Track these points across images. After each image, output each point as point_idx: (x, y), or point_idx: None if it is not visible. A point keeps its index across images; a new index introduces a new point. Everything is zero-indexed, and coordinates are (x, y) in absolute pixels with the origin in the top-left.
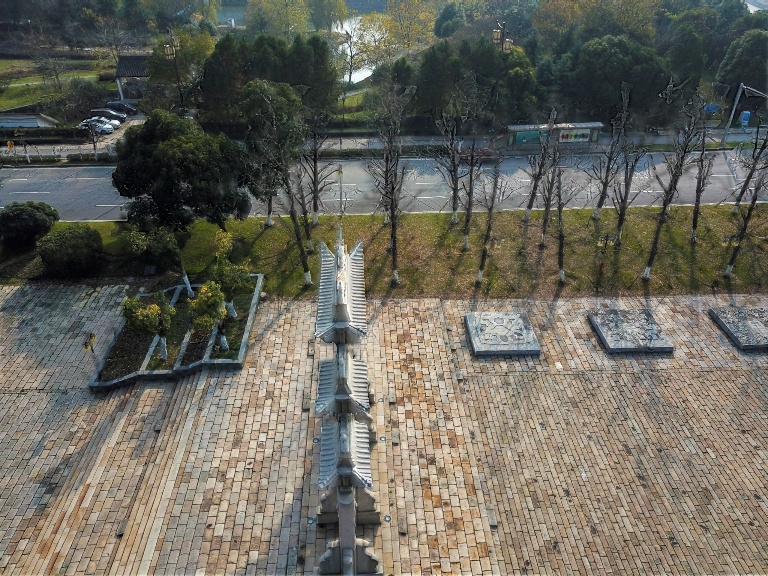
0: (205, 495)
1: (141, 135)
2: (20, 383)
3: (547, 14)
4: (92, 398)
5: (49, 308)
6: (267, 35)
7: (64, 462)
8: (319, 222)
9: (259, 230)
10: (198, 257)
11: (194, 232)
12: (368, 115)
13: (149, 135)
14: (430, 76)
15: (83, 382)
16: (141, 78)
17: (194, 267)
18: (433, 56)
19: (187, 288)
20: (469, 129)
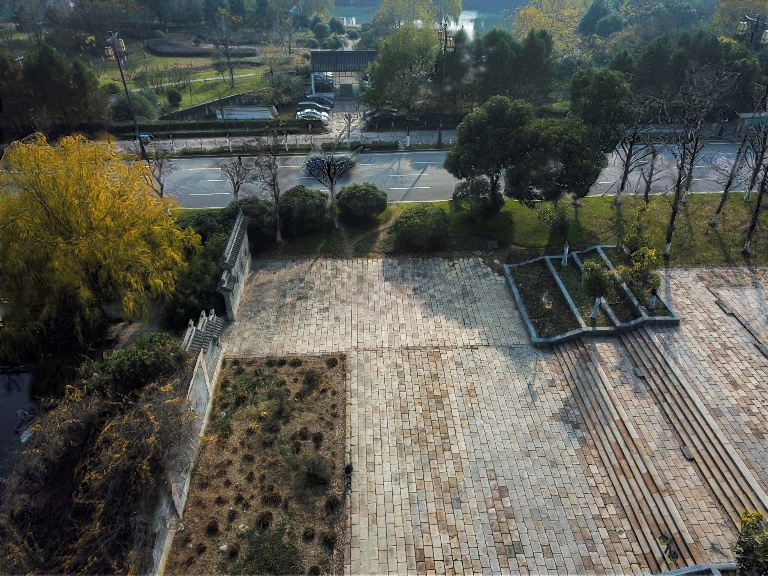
0: (749, 426)
1: (488, 120)
2: (463, 340)
3: (726, 8)
4: (541, 352)
5: (427, 278)
6: (498, 29)
7: (567, 404)
8: (621, 201)
9: (571, 209)
10: (534, 232)
11: (511, 211)
12: None
13: (493, 120)
14: (656, 67)
15: (519, 339)
16: (333, 73)
17: (536, 241)
18: (659, 48)
19: (563, 258)
20: None
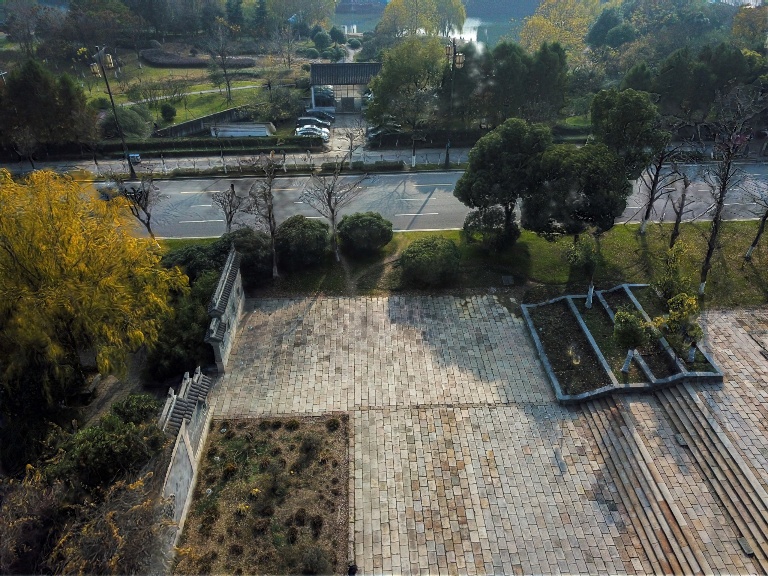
0: None
1: (502, 145)
2: (479, 396)
3: (746, 18)
4: (567, 412)
5: (438, 319)
6: (509, 42)
7: (600, 478)
8: (645, 230)
9: (592, 239)
10: (553, 267)
11: (527, 241)
12: (714, 123)
13: (509, 145)
14: (676, 82)
15: (542, 395)
16: (334, 86)
17: (556, 277)
18: (679, 62)
19: (588, 299)
20: (704, 135)
